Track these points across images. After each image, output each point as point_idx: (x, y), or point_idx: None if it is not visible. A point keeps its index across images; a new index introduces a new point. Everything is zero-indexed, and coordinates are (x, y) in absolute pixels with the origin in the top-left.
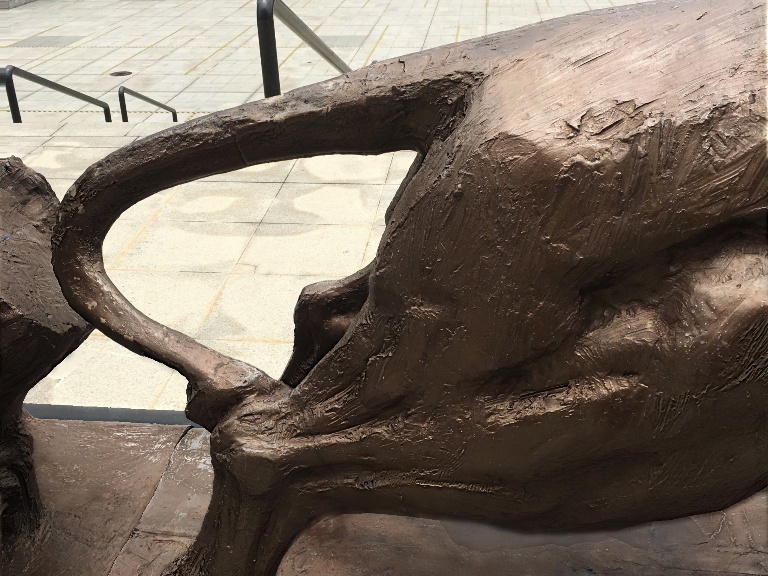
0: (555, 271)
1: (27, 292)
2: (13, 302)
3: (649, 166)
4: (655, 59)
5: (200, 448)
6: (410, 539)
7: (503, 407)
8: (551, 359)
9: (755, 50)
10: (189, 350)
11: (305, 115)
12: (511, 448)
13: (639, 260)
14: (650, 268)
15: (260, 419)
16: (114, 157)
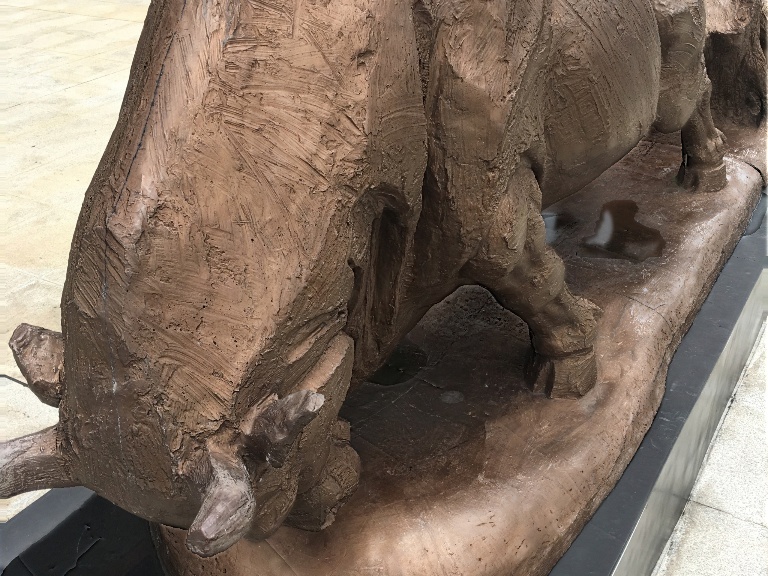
0: None
1: None
2: None
3: None
4: None
5: None
6: None
7: None
8: None
9: None
10: None
11: None
12: None
13: None
14: None
15: None
16: None
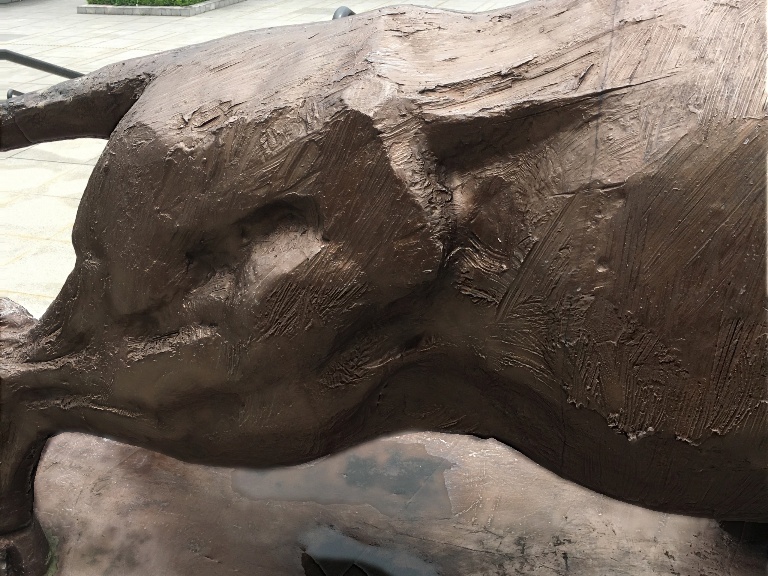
0: (163, 236)
1: None
2: None
3: (225, 154)
4: (265, 69)
5: None
6: (197, 482)
7: (140, 347)
8: (169, 309)
9: (329, 65)
10: None
11: (56, 103)
12: (140, 380)
13: (219, 231)
14: (229, 239)
15: (3, 346)
16: None
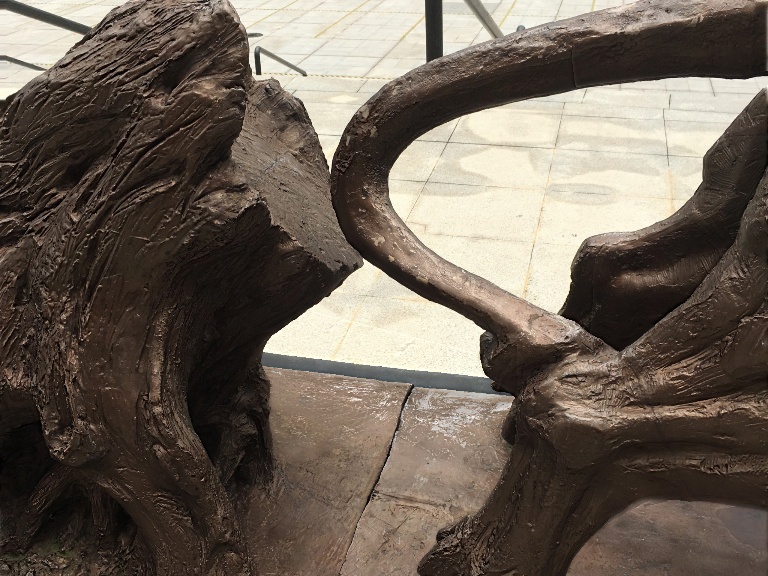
0: None
1: (301, 223)
2: (292, 233)
3: None
4: None
5: (431, 409)
6: (685, 531)
7: None
8: None
9: None
10: (495, 297)
11: (668, 26)
12: None
13: None
14: None
15: (585, 382)
16: (417, 74)
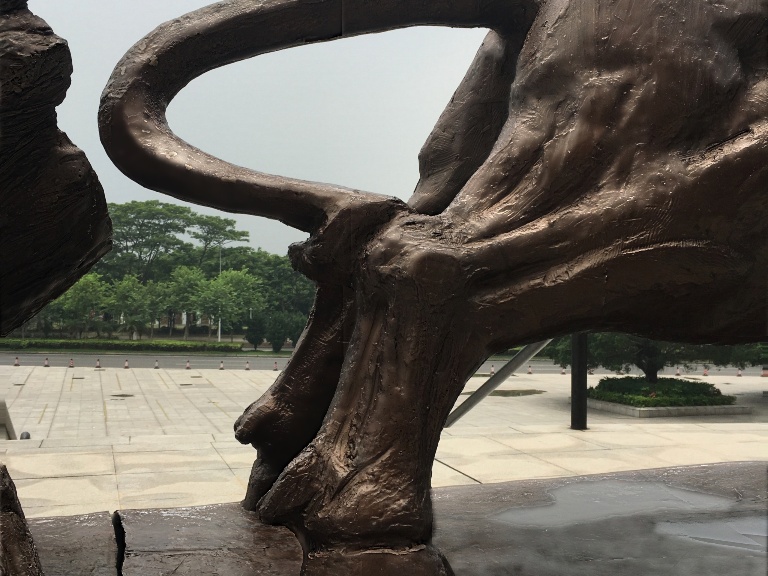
0: (721, 27)
1: None
2: None
3: None
4: None
5: None
6: (472, 527)
7: (695, 159)
8: (728, 109)
9: None
10: None
11: None
12: (717, 190)
13: None
14: None
15: (425, 227)
16: (194, 14)
